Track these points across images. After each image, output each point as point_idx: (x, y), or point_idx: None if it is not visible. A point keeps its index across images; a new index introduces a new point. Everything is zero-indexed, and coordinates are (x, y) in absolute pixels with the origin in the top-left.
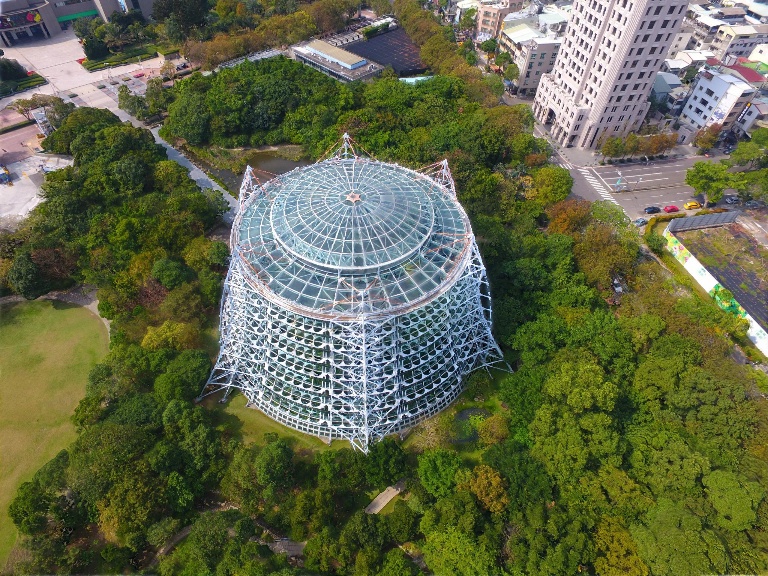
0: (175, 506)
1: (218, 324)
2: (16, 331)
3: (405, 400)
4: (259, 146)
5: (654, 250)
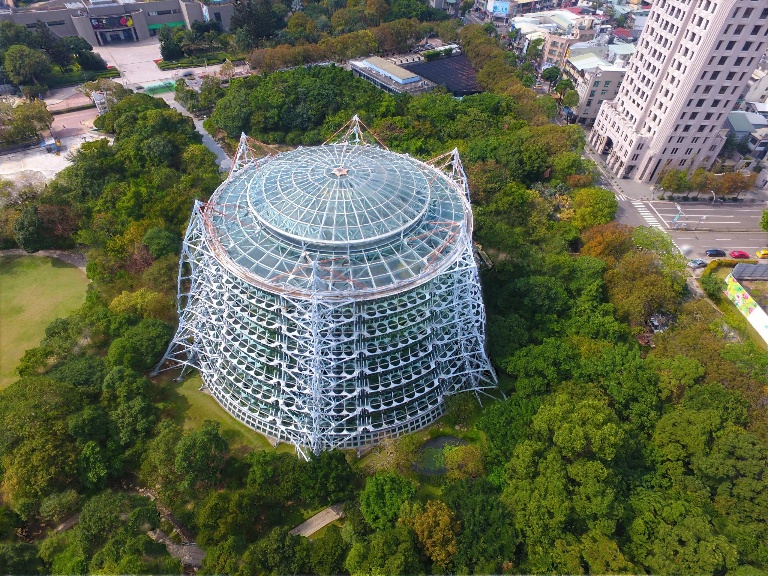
0: (85, 480)
1: None
2: (9, 281)
3: (368, 410)
4: (294, 145)
5: (711, 296)
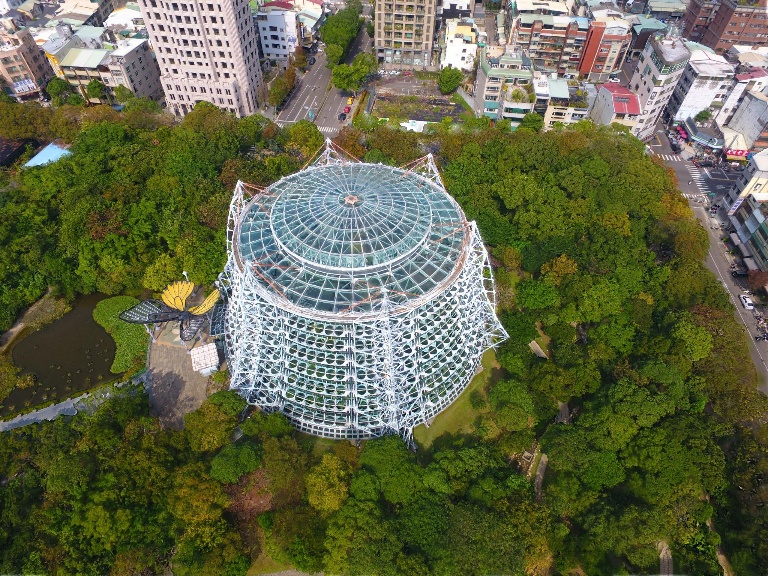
0: None
1: (312, 440)
2: None
3: None
4: None
5: None
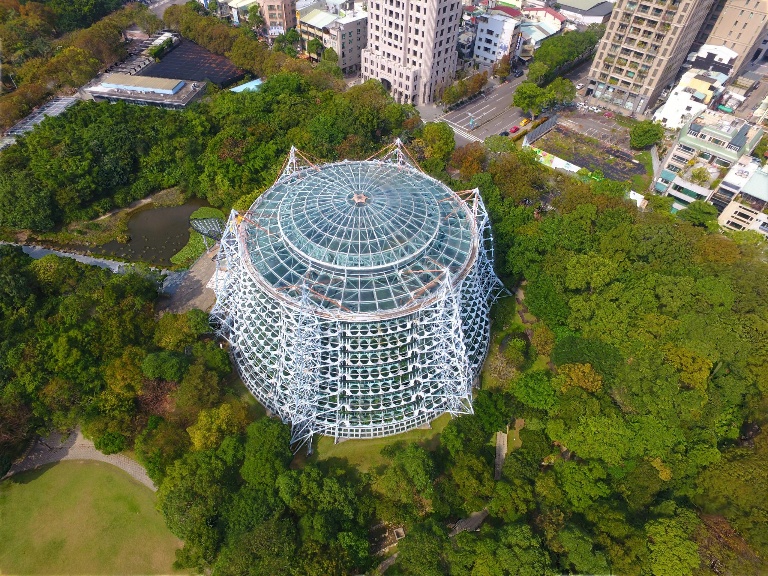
0: (358, 562)
1: (242, 390)
2: None
3: (469, 355)
4: (128, 204)
5: None
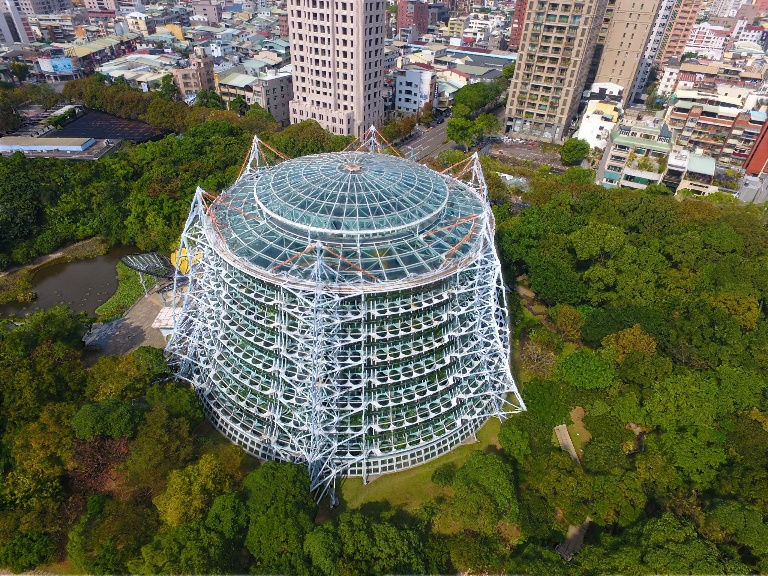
0: None
1: None
2: None
3: None
4: (31, 260)
5: None
